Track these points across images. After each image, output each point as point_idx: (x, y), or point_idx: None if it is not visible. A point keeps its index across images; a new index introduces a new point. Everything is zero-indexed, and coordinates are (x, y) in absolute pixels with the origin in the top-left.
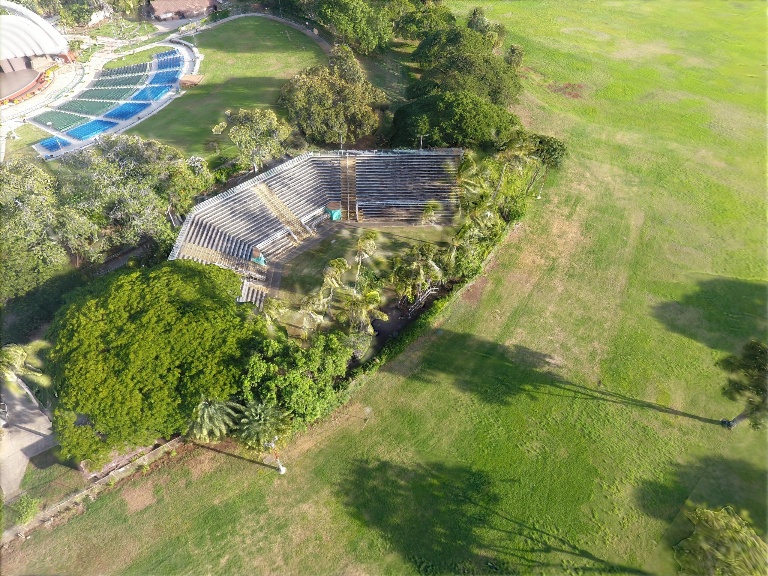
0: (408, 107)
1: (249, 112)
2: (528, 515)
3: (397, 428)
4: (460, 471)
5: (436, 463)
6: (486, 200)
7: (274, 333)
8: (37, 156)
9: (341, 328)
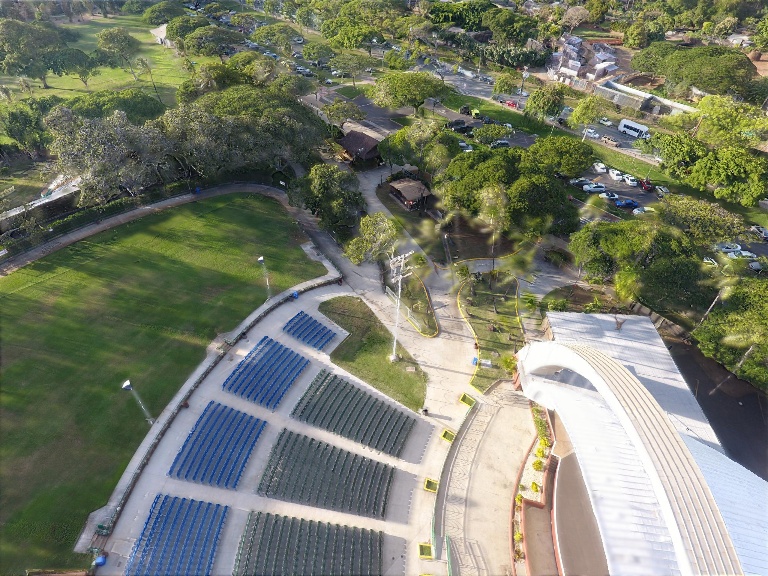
0: None
1: None
2: None
3: (10, 141)
4: None
5: (1, 134)
6: None
7: (37, 105)
8: (319, 306)
9: (10, 171)
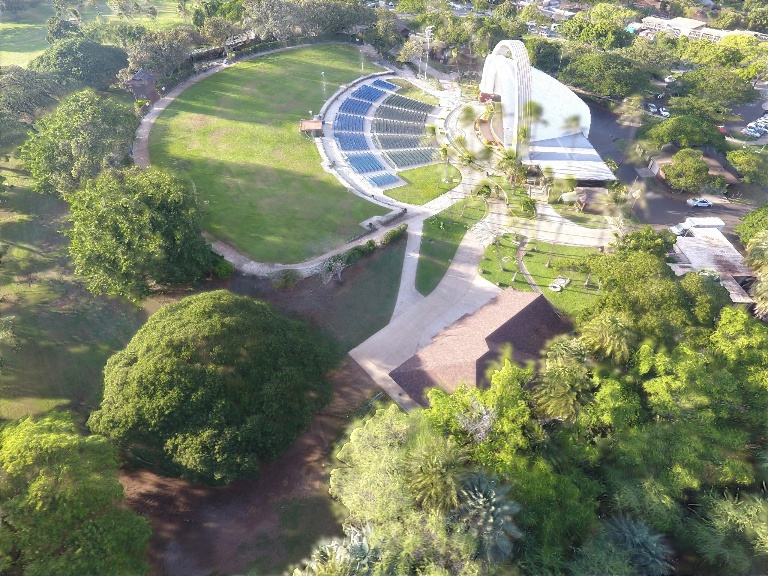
0: (109, 60)
1: (218, 18)
2: (156, 26)
3: None
4: (170, 29)
5: None
6: (118, 7)
7: (211, 5)
8: (386, 80)
9: None
